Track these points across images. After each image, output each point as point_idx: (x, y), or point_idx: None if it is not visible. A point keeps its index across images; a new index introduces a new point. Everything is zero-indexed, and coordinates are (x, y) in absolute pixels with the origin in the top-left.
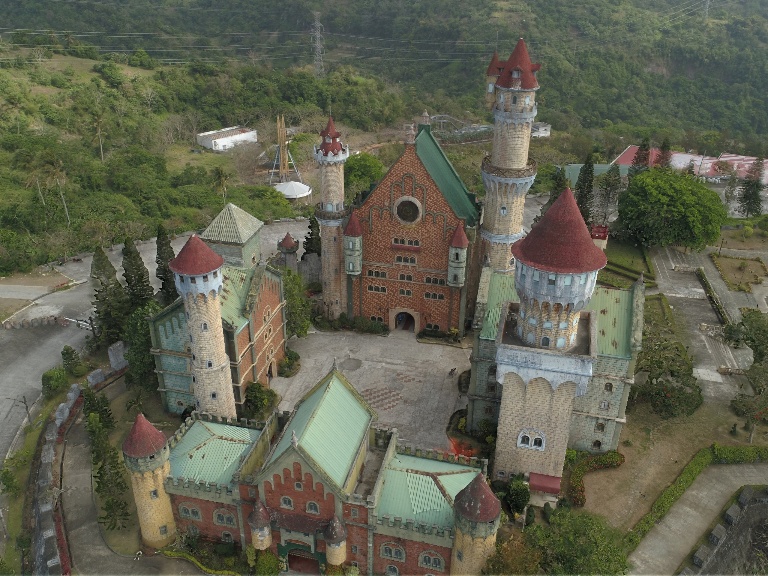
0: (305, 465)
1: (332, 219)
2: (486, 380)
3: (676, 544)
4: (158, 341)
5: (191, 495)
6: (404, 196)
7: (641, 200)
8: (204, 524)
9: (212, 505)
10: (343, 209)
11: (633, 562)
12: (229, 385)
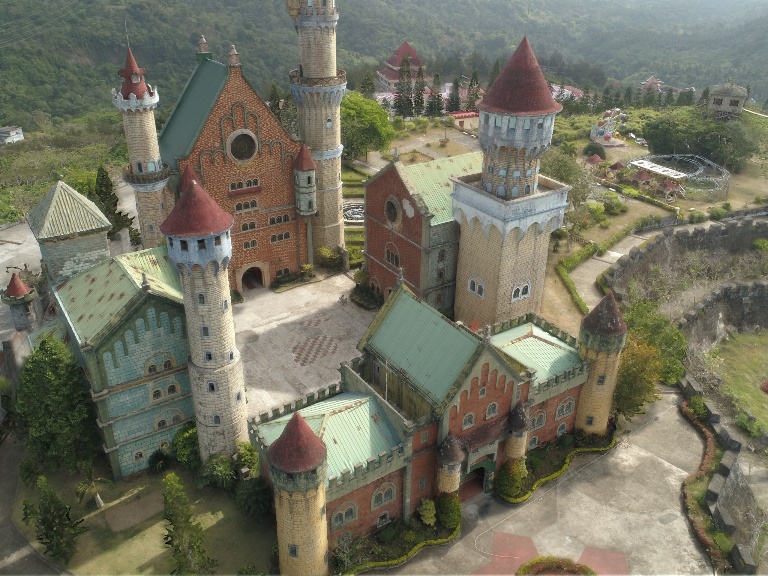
0: (493, 362)
1: (160, 180)
2: (436, 269)
3: None
4: (102, 378)
5: (357, 486)
6: (236, 130)
7: None
8: (358, 521)
9: (371, 488)
10: (162, 167)
11: None
12: None
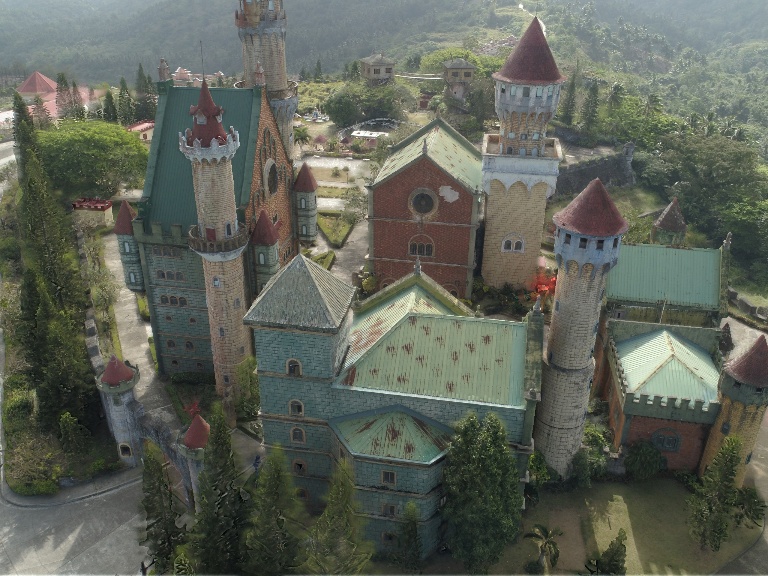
0: None
1: None
2: None
3: None
4: None
5: None
6: (267, 162)
7: (99, 152)
8: None
9: None
10: None
11: None
12: None
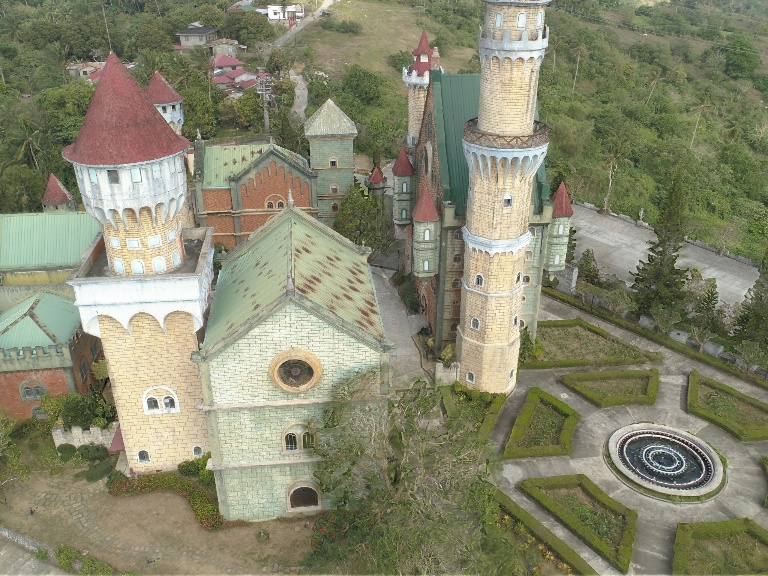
0: None
1: None
2: None
3: None
4: None
5: None
6: None
7: None
8: None
9: None
10: None
11: (47, 572)
12: None
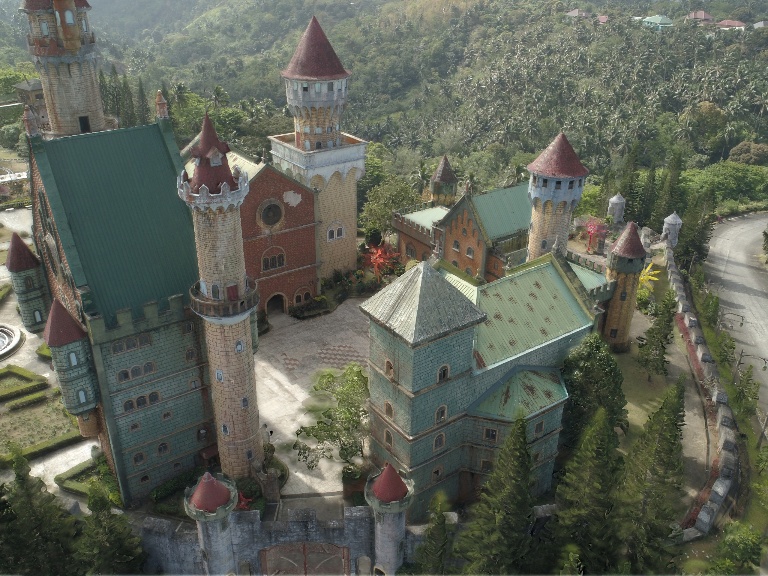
0: None
1: None
2: None
3: None
4: None
5: None
6: None
7: None
8: None
9: None
10: None
11: None
12: None
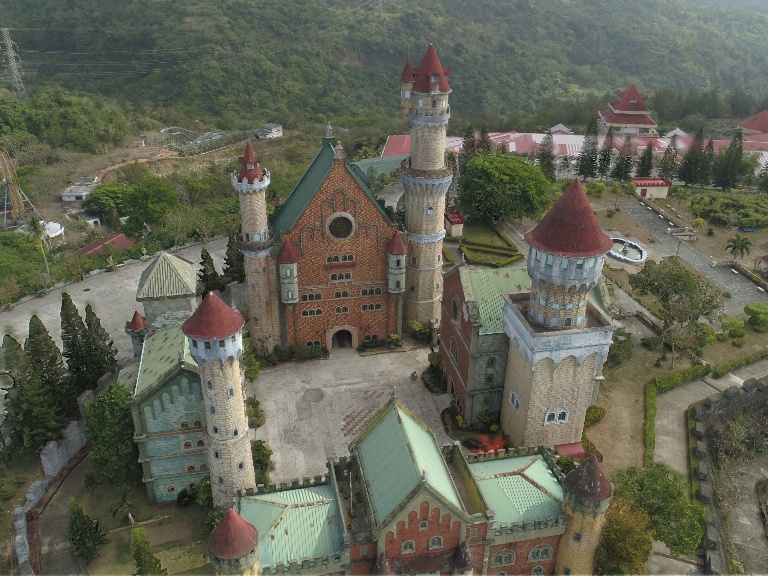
0: (433, 501)
1: (262, 249)
2: (484, 373)
3: (675, 469)
4: (143, 425)
5: None
6: (336, 213)
7: (485, 183)
8: None
9: None
10: (269, 237)
11: None
12: (250, 450)
